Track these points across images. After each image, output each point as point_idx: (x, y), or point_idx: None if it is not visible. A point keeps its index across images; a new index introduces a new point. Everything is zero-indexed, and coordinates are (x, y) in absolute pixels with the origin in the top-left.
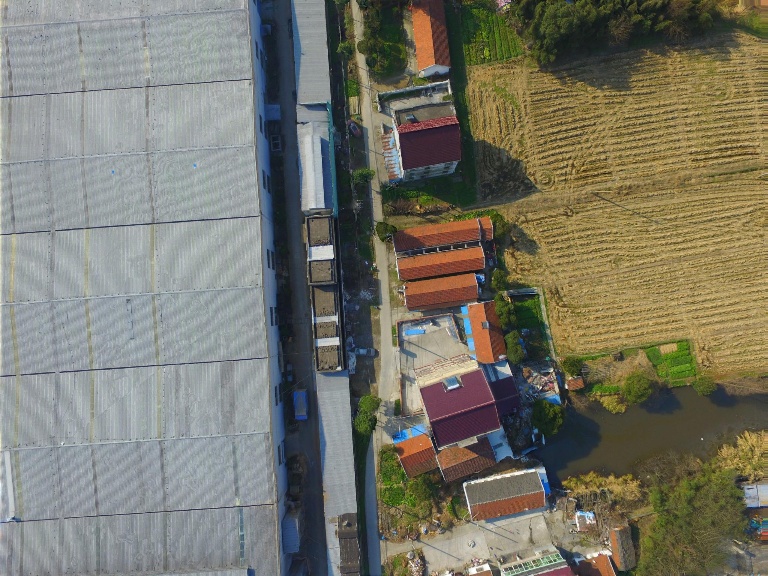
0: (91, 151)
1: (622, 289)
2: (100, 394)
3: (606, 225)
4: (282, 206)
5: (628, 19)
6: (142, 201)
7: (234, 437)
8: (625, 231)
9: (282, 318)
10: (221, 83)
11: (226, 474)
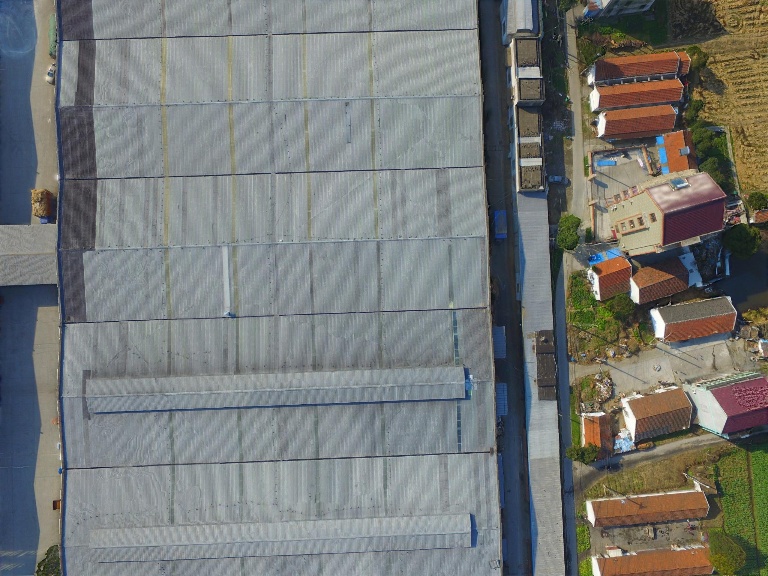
0: None
1: None
2: (317, 195)
3: None
4: None
5: None
6: (359, 9)
7: (451, 240)
8: None
9: None
10: None
11: (441, 277)
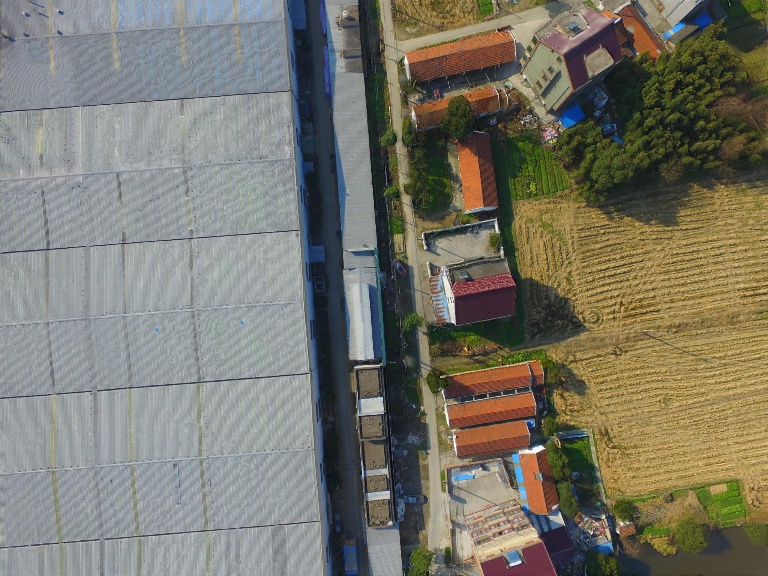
0: (134, 308)
1: (672, 429)
2: (147, 562)
3: (655, 364)
4: (327, 348)
5: (679, 163)
6: (187, 359)
7: None
8: (674, 370)
9: (329, 465)
10: (267, 234)
11: None
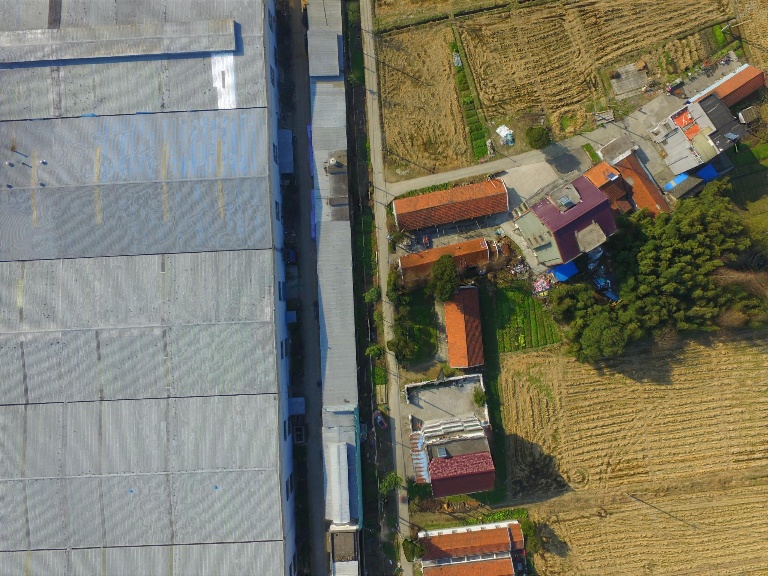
0: (109, 469)
1: None
2: None
3: (641, 528)
4: (304, 499)
5: (674, 331)
6: (161, 520)
7: None
8: (660, 535)
9: None
10: (245, 396)
11: None
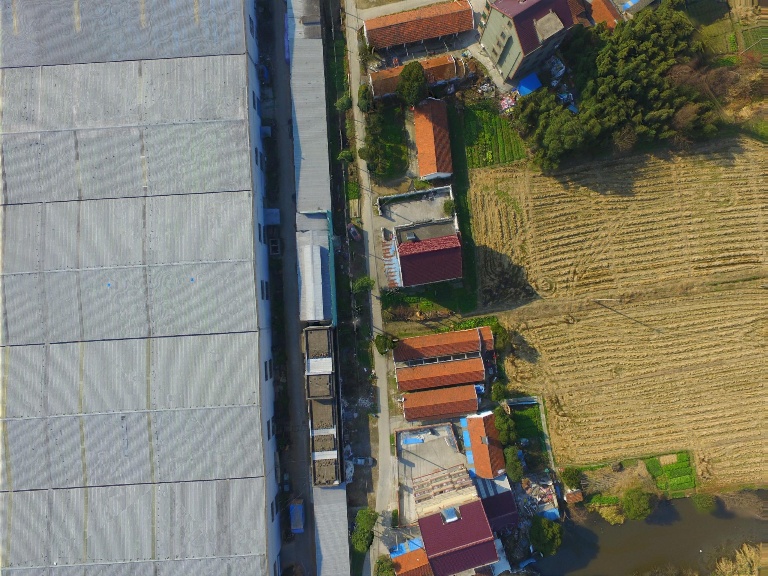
0: (87, 263)
1: (622, 399)
2: (94, 512)
3: (607, 333)
4: (280, 310)
5: (632, 131)
6: (138, 314)
7: (229, 559)
8: (626, 340)
9: (279, 425)
10: (220, 194)
11: None
